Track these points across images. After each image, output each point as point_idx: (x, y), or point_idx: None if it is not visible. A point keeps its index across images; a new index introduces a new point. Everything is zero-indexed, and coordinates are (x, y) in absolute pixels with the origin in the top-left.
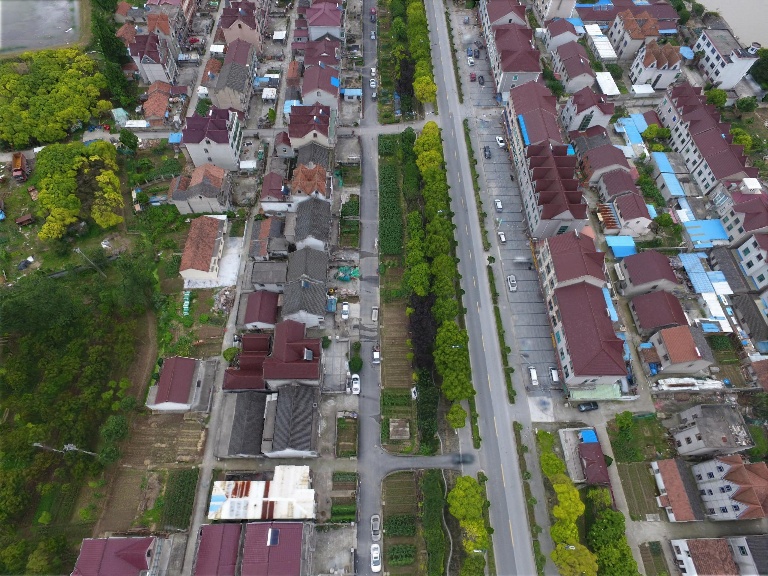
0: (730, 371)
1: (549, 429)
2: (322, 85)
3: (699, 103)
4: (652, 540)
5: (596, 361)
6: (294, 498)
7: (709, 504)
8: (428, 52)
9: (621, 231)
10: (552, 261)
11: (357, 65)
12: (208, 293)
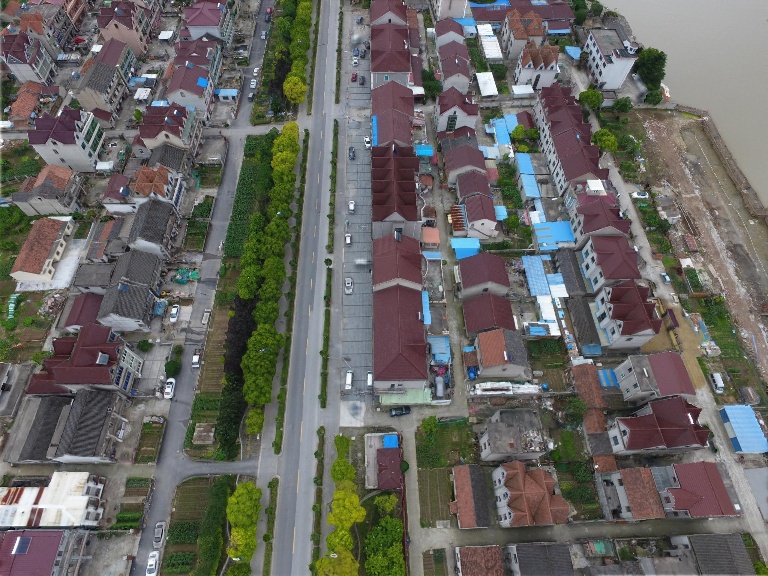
0: (553, 375)
1: (355, 434)
2: (186, 85)
3: (564, 104)
4: (437, 547)
5: (394, 365)
6: (64, 505)
7: (499, 511)
8: (312, 52)
9: (468, 233)
10: (372, 264)
11: (241, 65)
12: (38, 296)
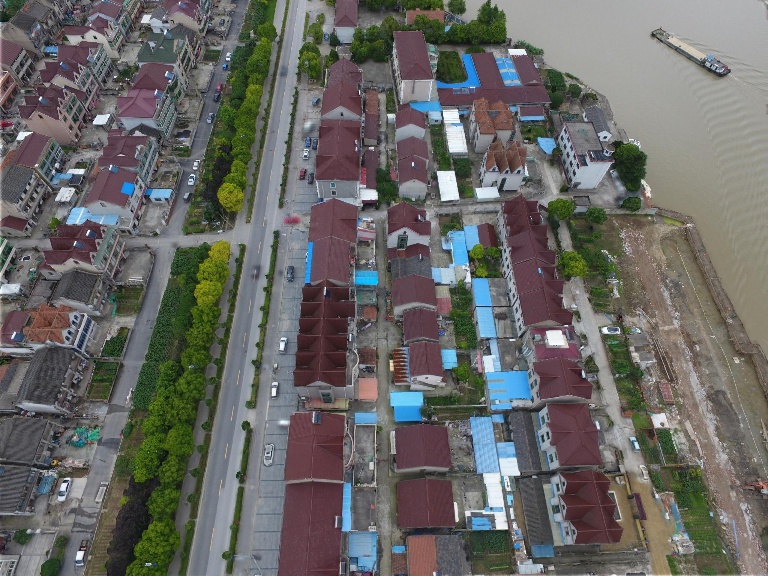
0: None
1: None
2: (106, 195)
3: (527, 223)
4: None
5: None
6: None
7: None
8: (259, 143)
9: (411, 385)
10: (286, 449)
11: (181, 156)
12: None
